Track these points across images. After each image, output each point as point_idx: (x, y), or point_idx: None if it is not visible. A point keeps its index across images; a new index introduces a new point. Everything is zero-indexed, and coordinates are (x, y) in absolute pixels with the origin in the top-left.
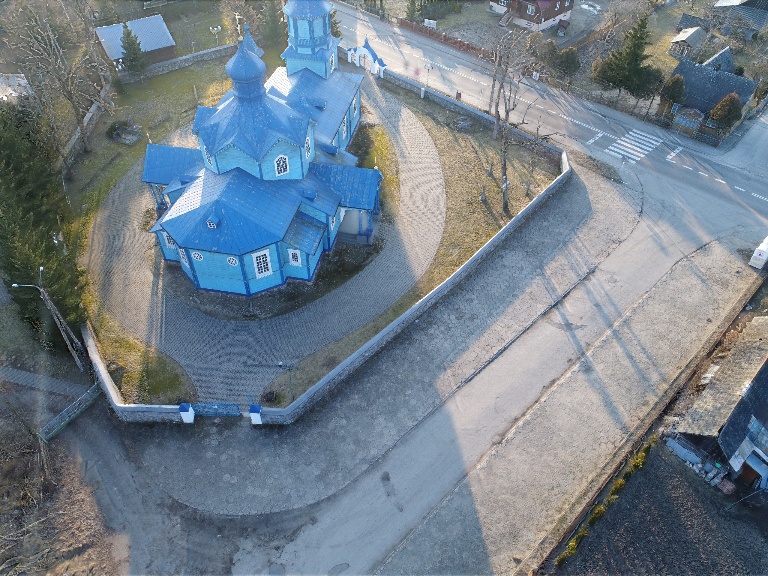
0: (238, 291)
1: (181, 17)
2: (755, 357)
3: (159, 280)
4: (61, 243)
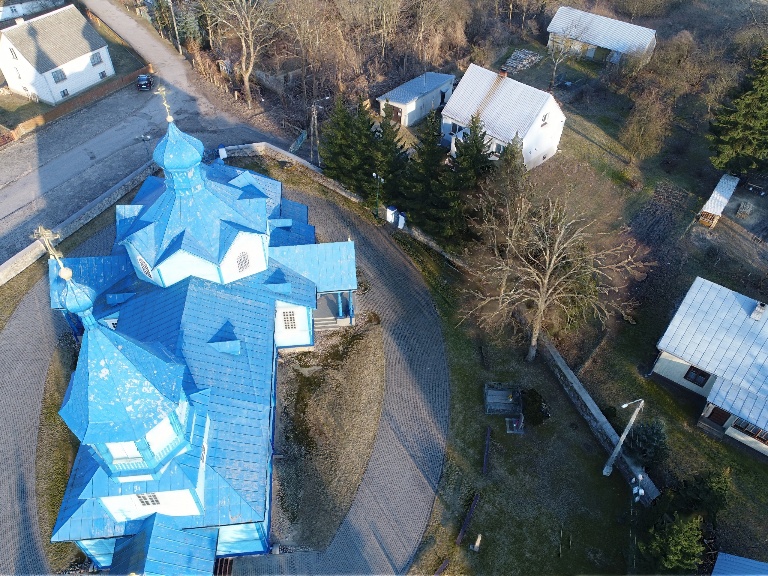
0: None
1: None
2: None
3: None
4: (409, 223)
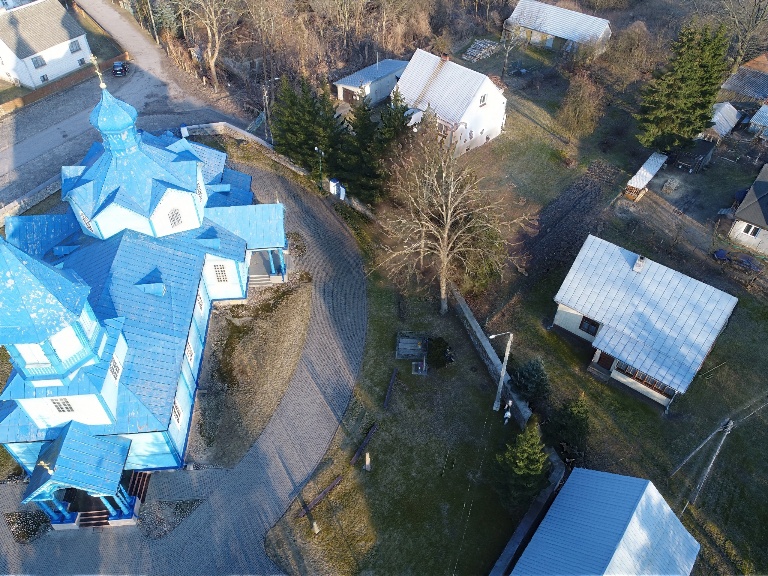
0: None
1: None
2: None
3: None
4: (348, 194)
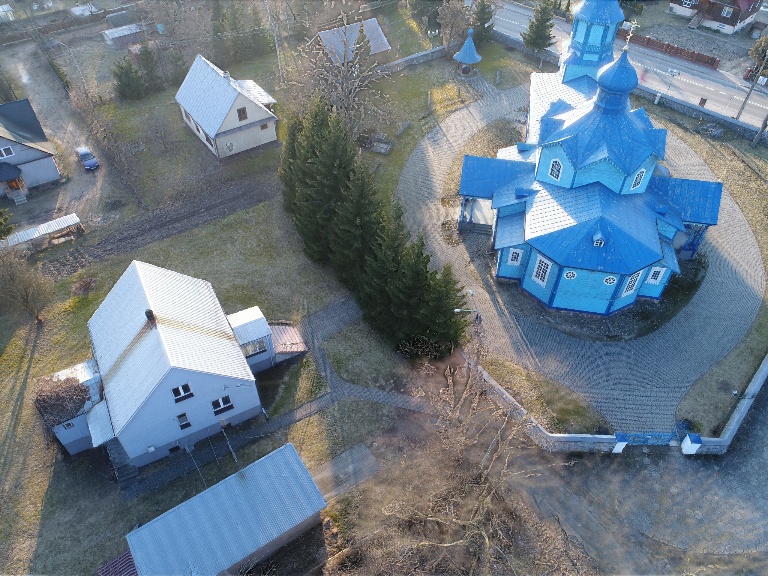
0: (595, 310)
1: (385, 20)
2: None
3: (497, 298)
4: None
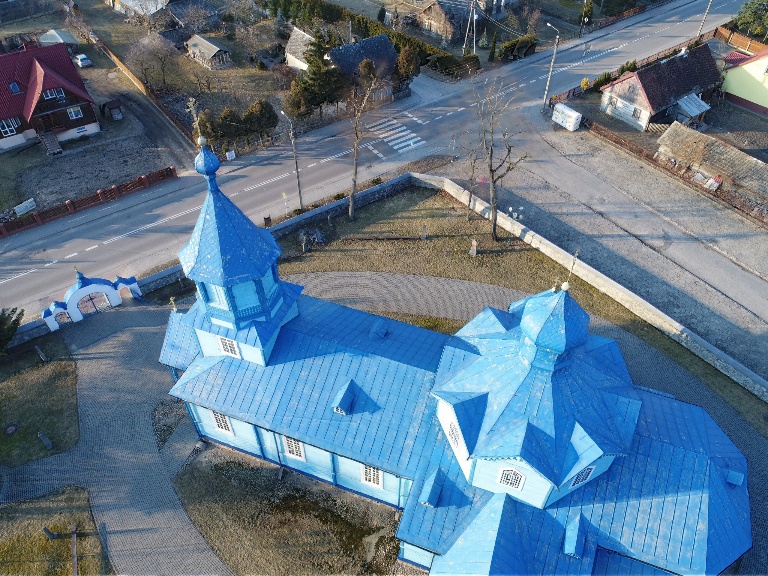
0: None
1: None
2: (720, 149)
3: None
4: None
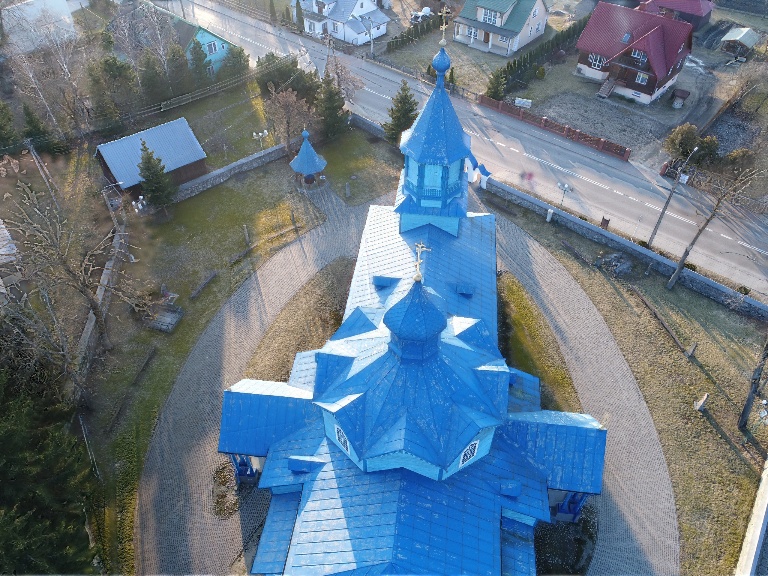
0: None
1: (207, 113)
2: None
3: None
4: (96, 572)
